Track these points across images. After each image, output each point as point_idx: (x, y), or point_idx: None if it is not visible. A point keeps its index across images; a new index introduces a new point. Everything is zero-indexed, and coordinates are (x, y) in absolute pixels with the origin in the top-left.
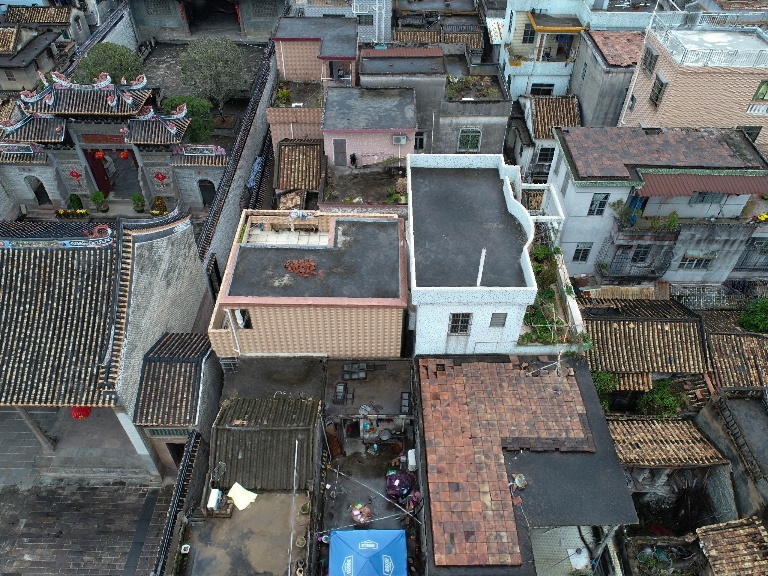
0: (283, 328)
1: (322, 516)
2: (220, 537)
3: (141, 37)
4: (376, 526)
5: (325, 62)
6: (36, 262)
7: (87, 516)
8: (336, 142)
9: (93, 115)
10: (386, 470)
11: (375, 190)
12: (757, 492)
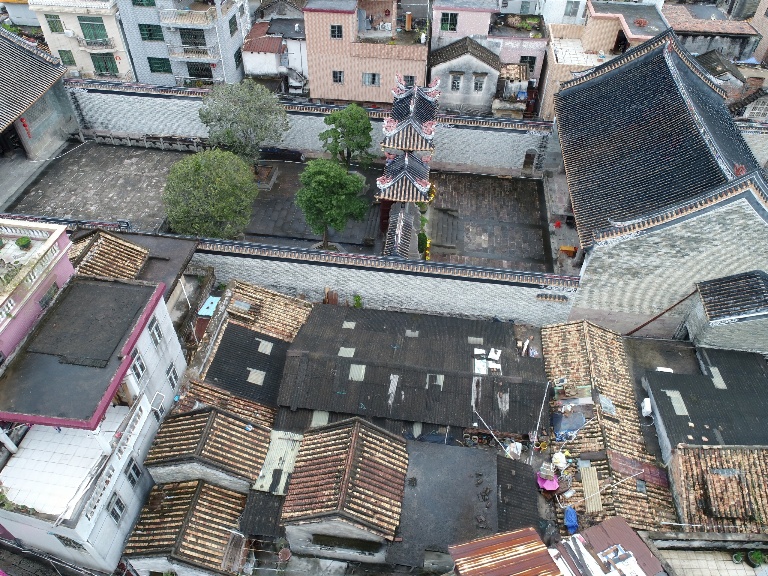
0: None
1: None
2: (767, 85)
3: None
4: None
5: None
6: None
7: None
8: None
9: None
10: None
11: (513, 33)
12: (673, 2)
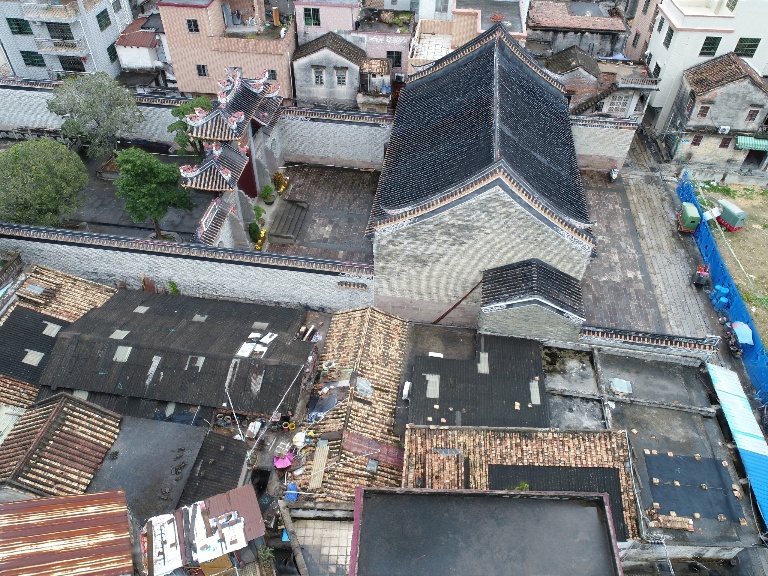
0: None
1: None
2: (622, 80)
3: None
4: None
5: None
6: None
7: None
8: None
9: None
10: None
11: (384, 29)
12: None
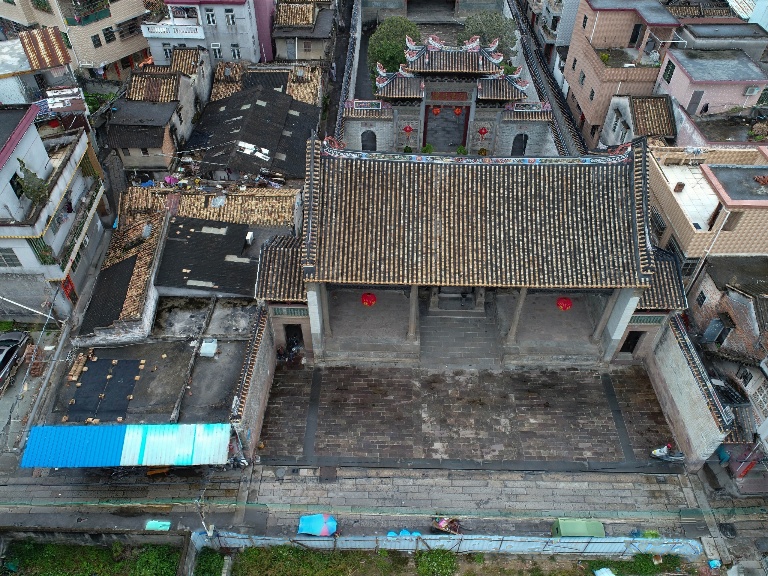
0: (759, 229)
1: None
2: None
3: (364, 17)
4: None
5: (650, 29)
6: (559, 176)
7: (562, 392)
8: (695, 93)
9: (453, 74)
10: None
11: (733, 133)
12: None
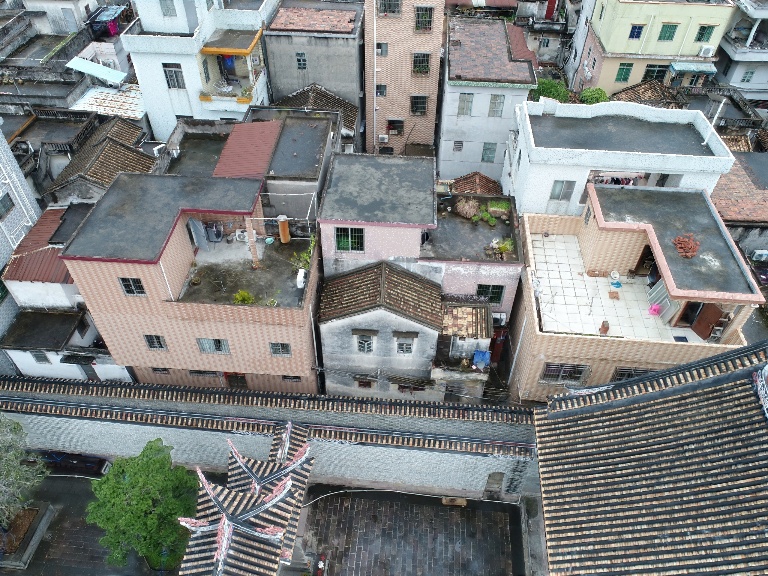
0: None
1: None
2: None
3: None
4: None
5: None
6: None
7: None
8: None
9: None
10: None
11: (466, 234)
12: None
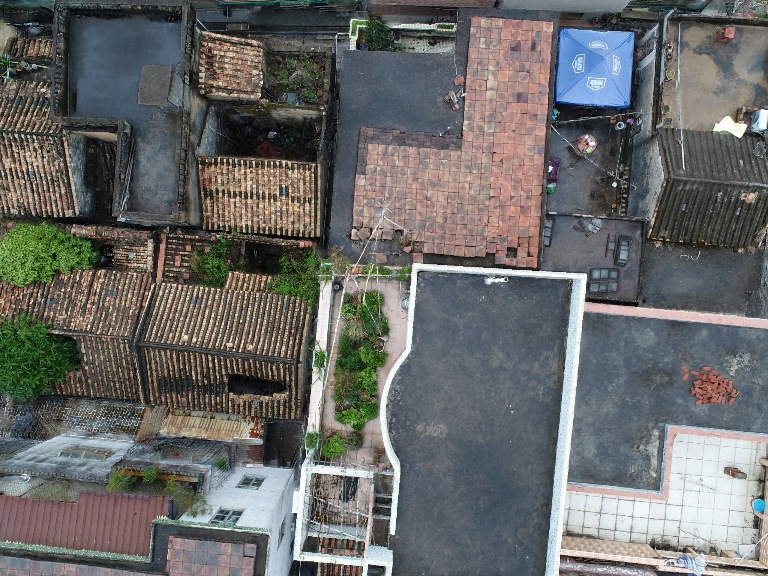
0: None
1: (625, 146)
2: (746, 91)
3: None
4: (571, 134)
5: None
6: None
7: None
8: None
9: None
10: (553, 197)
11: None
12: None
